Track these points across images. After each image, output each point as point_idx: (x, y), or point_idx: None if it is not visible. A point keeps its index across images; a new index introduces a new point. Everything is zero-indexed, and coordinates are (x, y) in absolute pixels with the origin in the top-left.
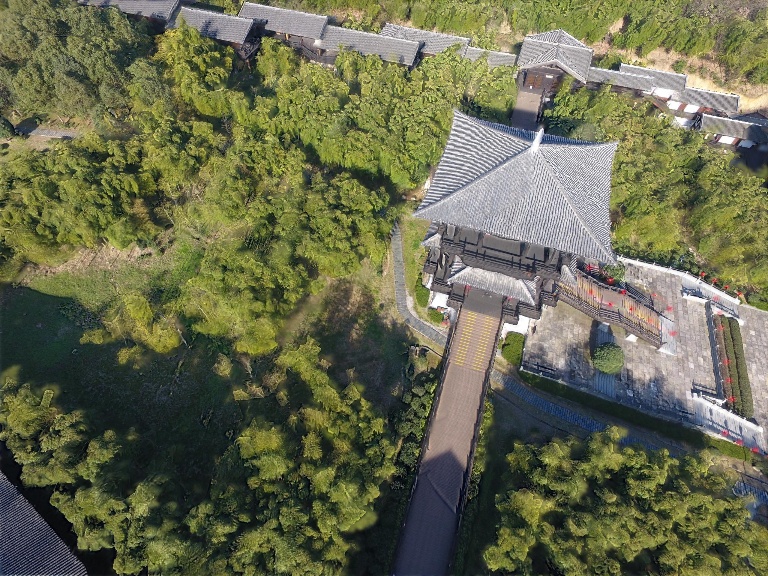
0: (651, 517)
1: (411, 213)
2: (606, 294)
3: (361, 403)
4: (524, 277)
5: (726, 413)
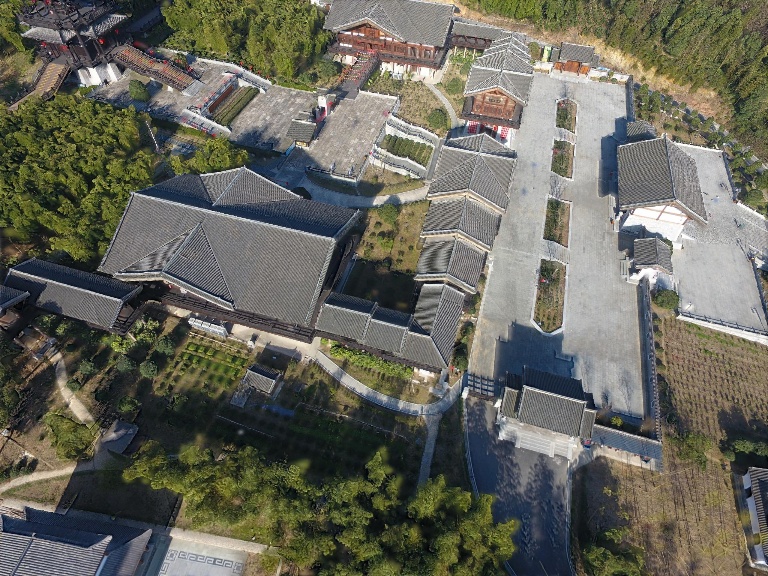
0: (65, 115)
1: None
2: (157, 65)
3: None
4: (54, 27)
5: (205, 120)
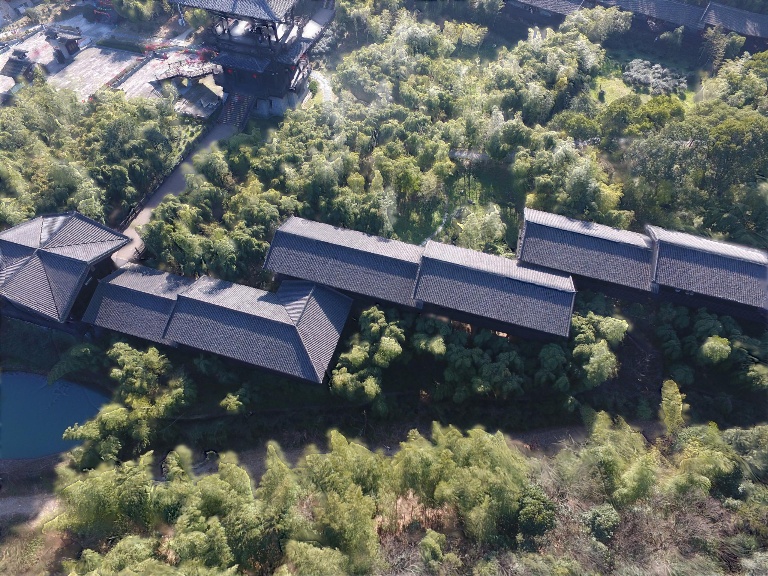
0: None
1: None
2: None
3: (350, 11)
4: None
5: None
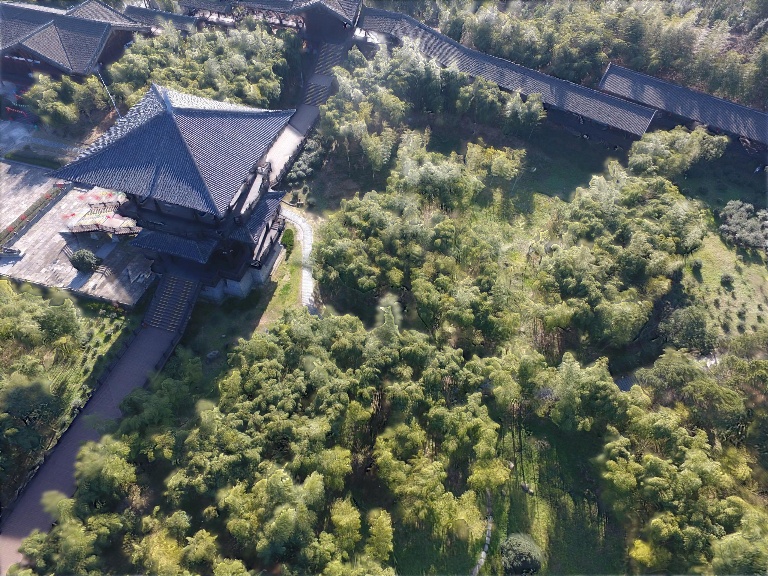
0: None
1: None
2: None
3: (339, 125)
4: None
5: None
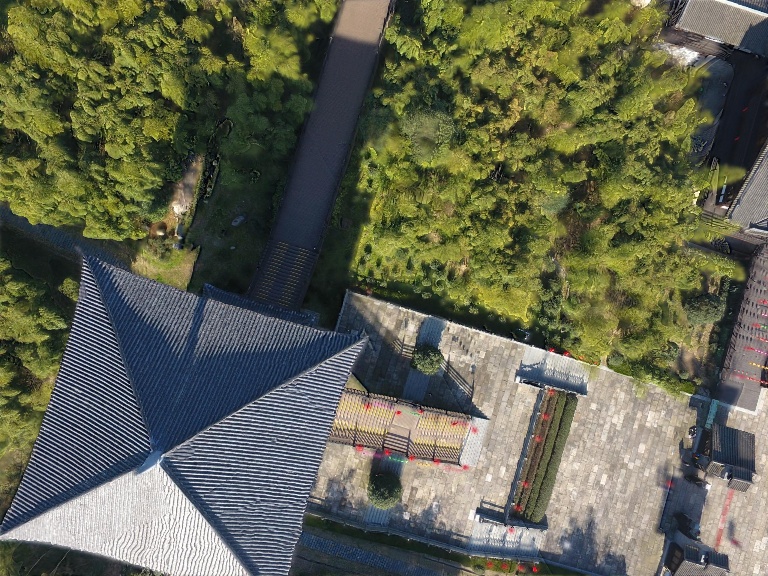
0: None
1: (158, 260)
2: (401, 410)
3: None
4: None
5: None
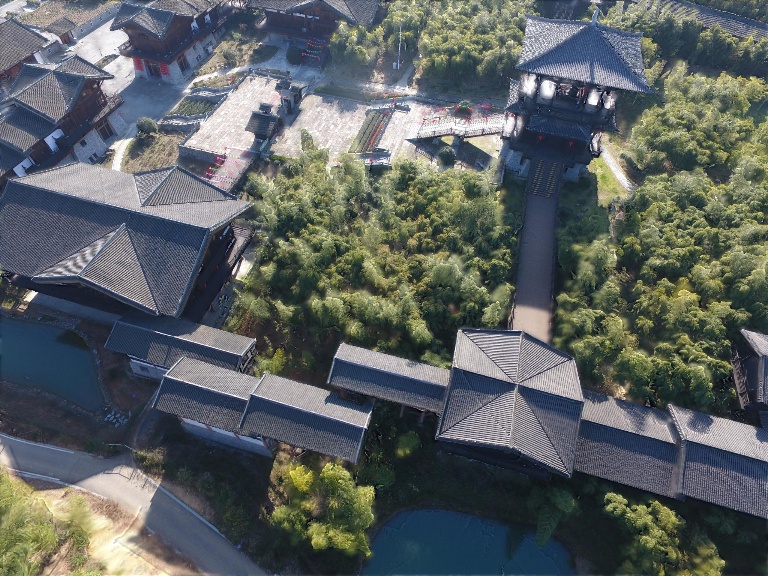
0: None
1: None
2: None
3: None
4: None
5: (390, 109)
